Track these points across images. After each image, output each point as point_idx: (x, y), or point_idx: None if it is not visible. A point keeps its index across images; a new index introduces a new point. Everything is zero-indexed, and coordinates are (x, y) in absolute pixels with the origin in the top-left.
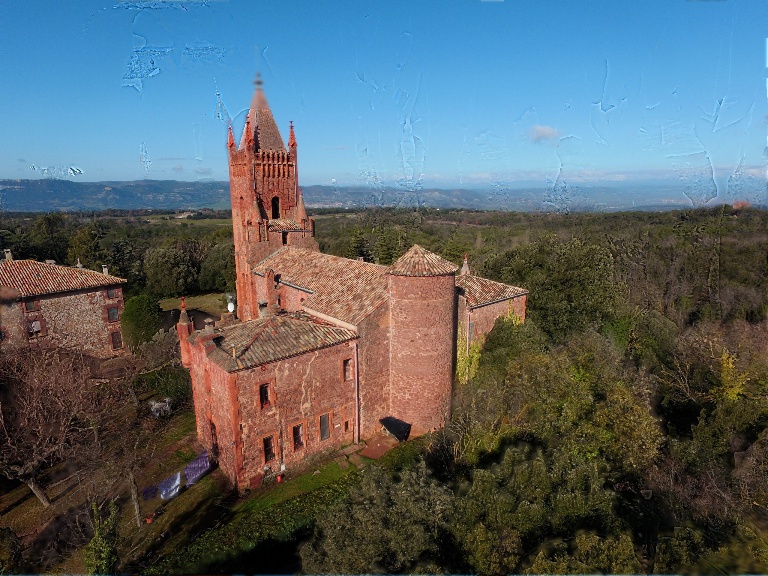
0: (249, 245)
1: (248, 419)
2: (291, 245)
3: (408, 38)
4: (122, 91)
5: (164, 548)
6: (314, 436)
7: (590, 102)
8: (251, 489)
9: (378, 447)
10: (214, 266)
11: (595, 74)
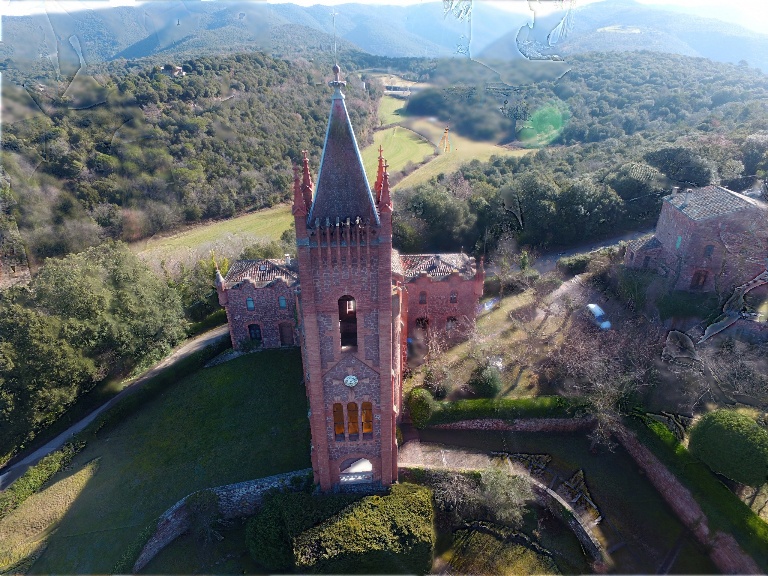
0: None
1: None
2: None
3: None
4: (533, 133)
5: (490, 299)
6: None
7: None
8: None
9: None
10: None
11: None
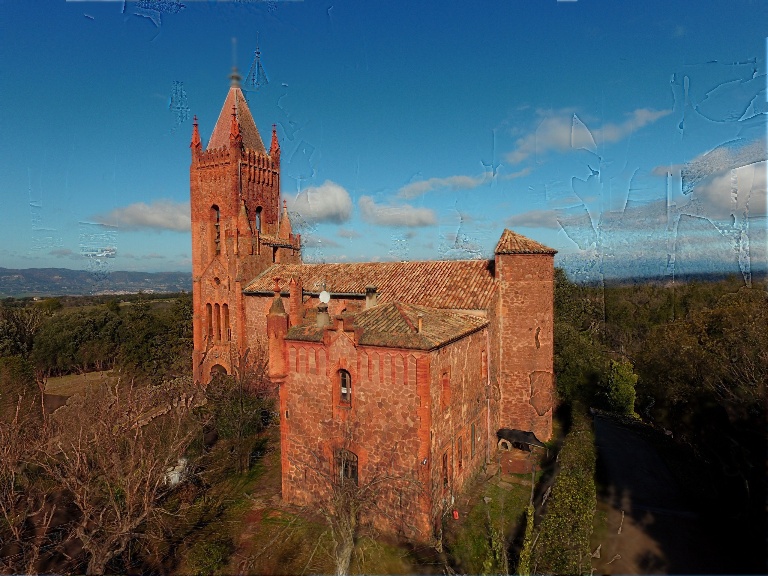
0: (237, 259)
1: (435, 424)
2: (281, 263)
3: (302, 98)
4: (134, 20)
5: None
6: (467, 453)
7: (483, 164)
8: (436, 535)
9: (513, 463)
10: (55, 339)
11: (484, 142)
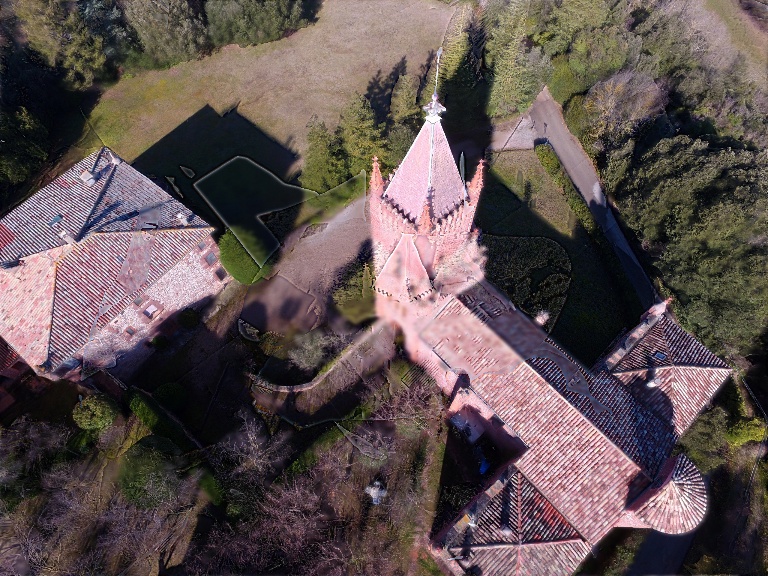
0: None
1: None
2: None
3: None
4: None
5: None
6: None
7: None
8: None
9: None
10: (225, 11)
11: None
